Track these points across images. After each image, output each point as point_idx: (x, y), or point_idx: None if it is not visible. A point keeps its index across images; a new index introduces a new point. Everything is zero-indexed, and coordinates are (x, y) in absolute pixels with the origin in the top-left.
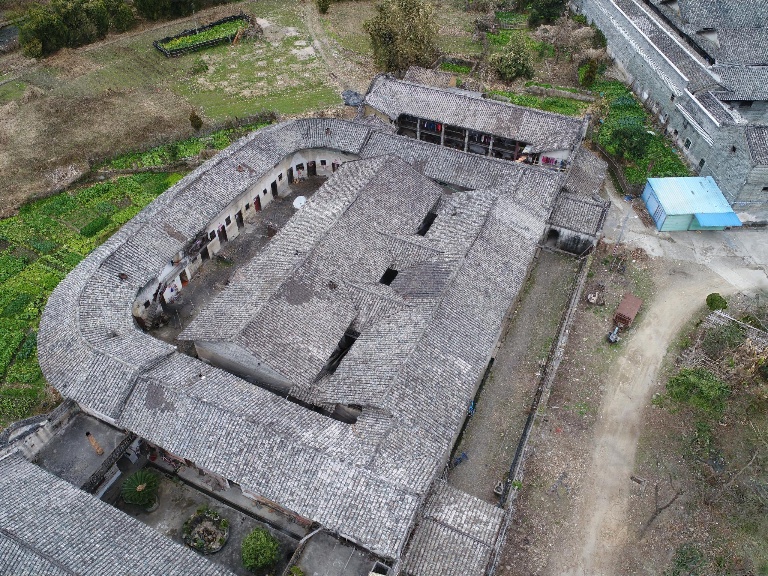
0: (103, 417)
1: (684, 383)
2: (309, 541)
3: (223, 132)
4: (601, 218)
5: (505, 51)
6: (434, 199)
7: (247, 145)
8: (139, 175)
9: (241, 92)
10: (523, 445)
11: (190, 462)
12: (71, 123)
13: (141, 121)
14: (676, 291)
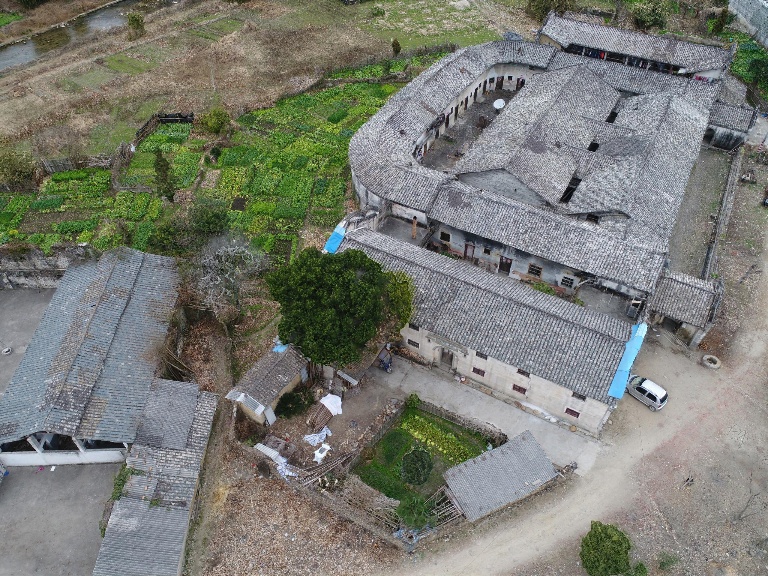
0: (413, 215)
1: None
2: (579, 289)
3: (415, 58)
4: (753, 118)
5: (644, 3)
6: (615, 100)
7: (463, 55)
8: (359, 84)
9: (418, 31)
10: (708, 262)
11: (466, 256)
12: (287, 48)
13: (343, 49)
14: None
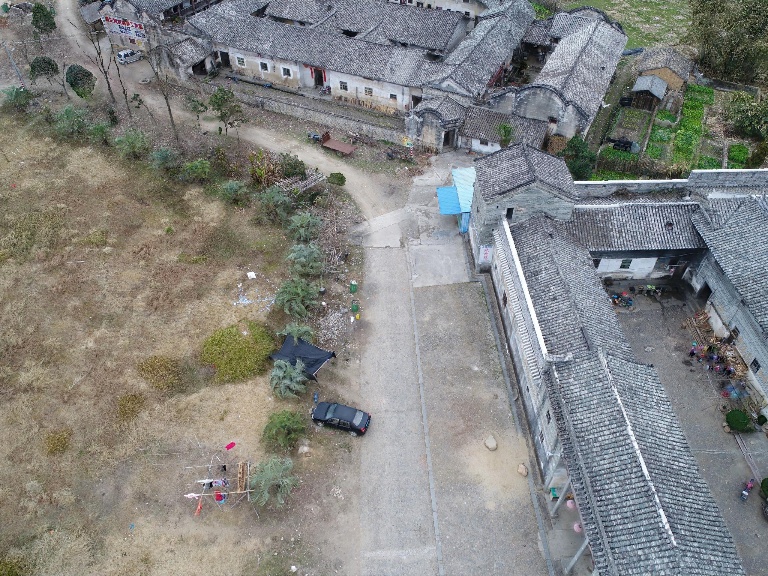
0: None
1: None
2: None
3: (541, 8)
4: None
5: None
6: (430, 46)
7: None
8: None
9: None
10: None
11: None
12: None
13: None
14: (367, 182)
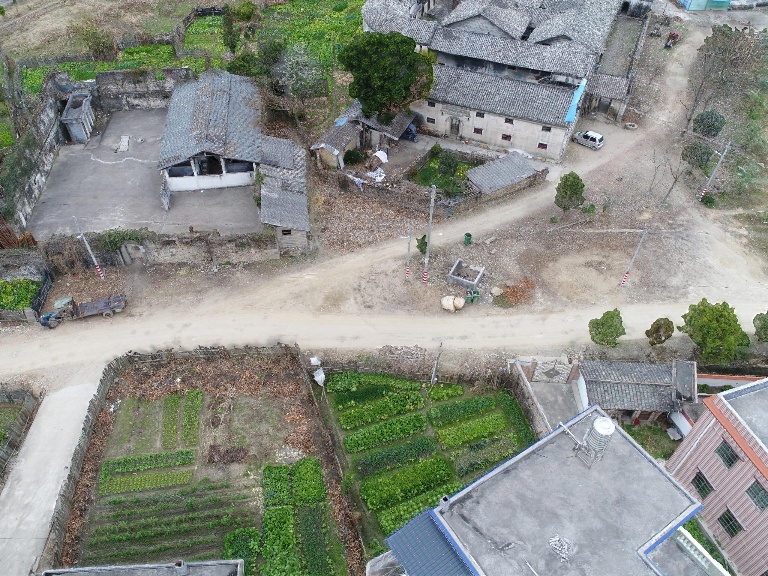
0: (417, 50)
1: (714, 31)
2: None
3: None
4: None
5: None
6: None
7: None
8: None
9: None
10: None
11: None
12: None
13: None
14: (701, 32)
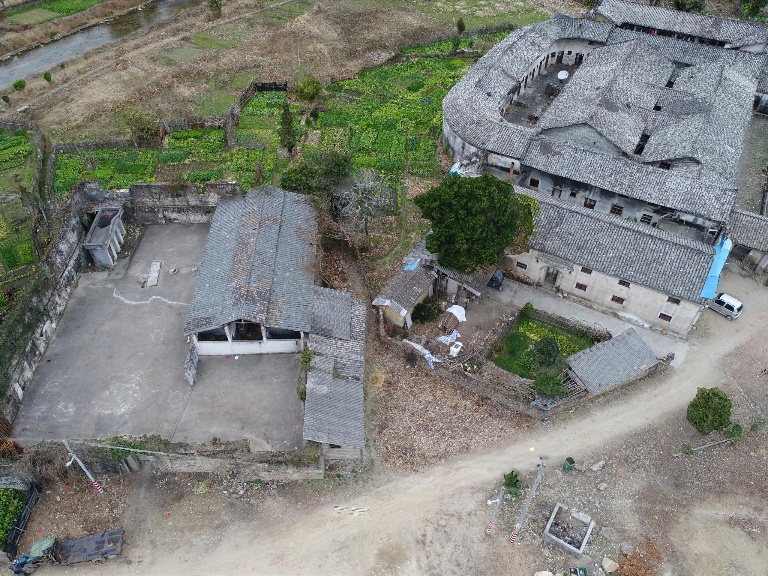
0: (507, 163)
1: None
2: (660, 223)
3: (477, 36)
4: None
5: None
6: (671, 70)
7: (531, 30)
8: (431, 58)
9: (475, 13)
10: (764, 206)
11: None
12: (357, 28)
13: (409, 28)
14: None
